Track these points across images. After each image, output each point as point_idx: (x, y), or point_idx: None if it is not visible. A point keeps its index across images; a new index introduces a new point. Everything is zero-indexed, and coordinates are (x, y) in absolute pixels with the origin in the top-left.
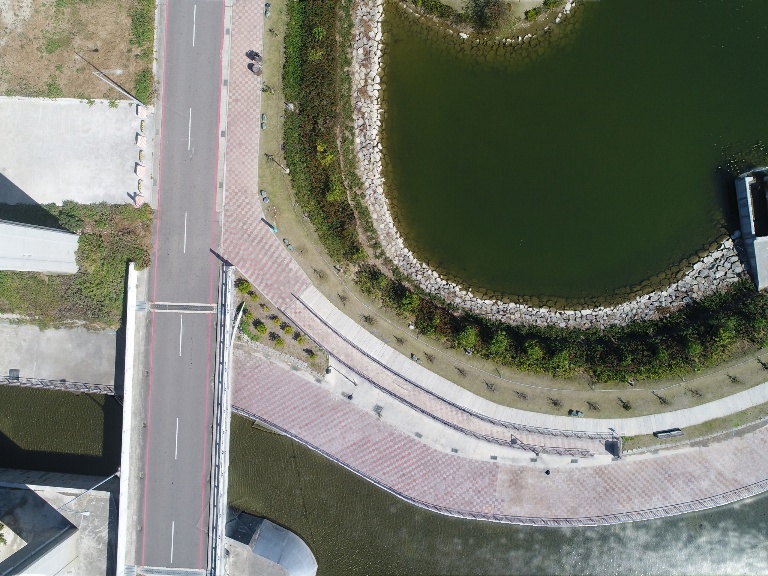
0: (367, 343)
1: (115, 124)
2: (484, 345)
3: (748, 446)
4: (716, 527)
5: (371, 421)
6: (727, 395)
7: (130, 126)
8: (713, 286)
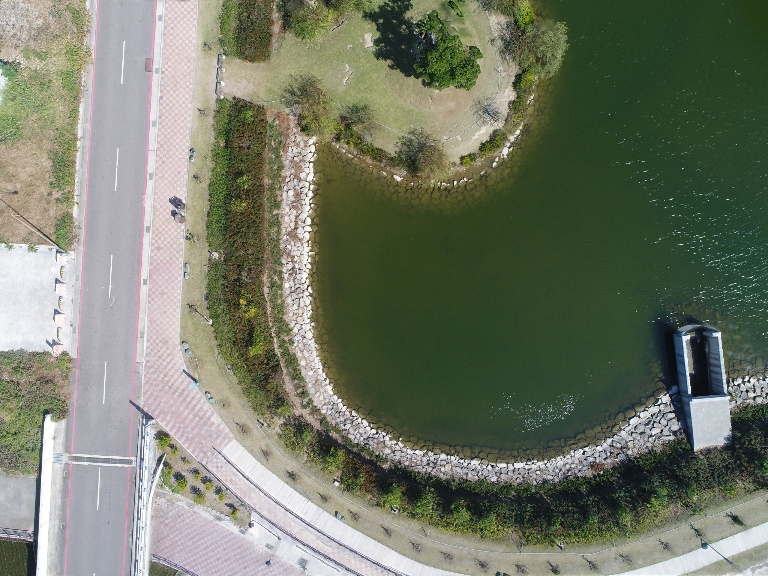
0: (290, 500)
1: (34, 269)
2: (410, 505)
3: None
4: None
5: (296, 574)
6: (659, 561)
7: (49, 272)
8: (648, 443)
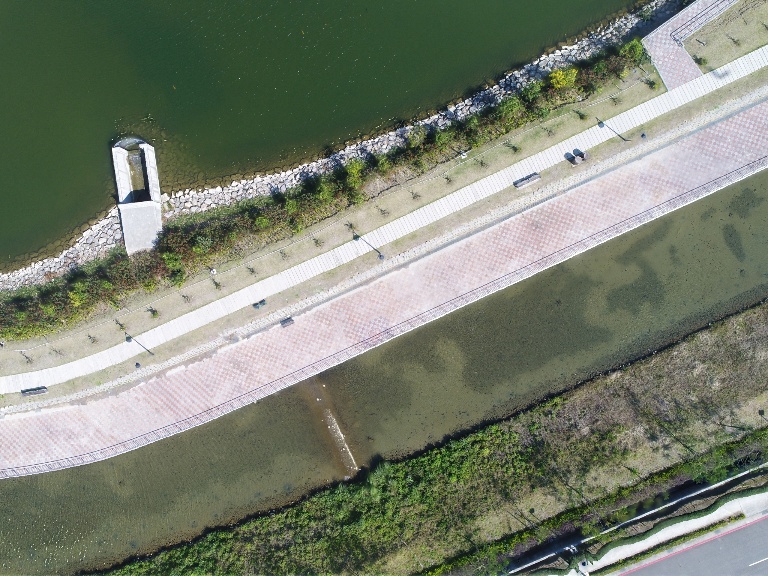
0: None
1: None
2: None
3: (123, 404)
4: (135, 484)
5: None
6: (88, 355)
7: None
8: (95, 252)
